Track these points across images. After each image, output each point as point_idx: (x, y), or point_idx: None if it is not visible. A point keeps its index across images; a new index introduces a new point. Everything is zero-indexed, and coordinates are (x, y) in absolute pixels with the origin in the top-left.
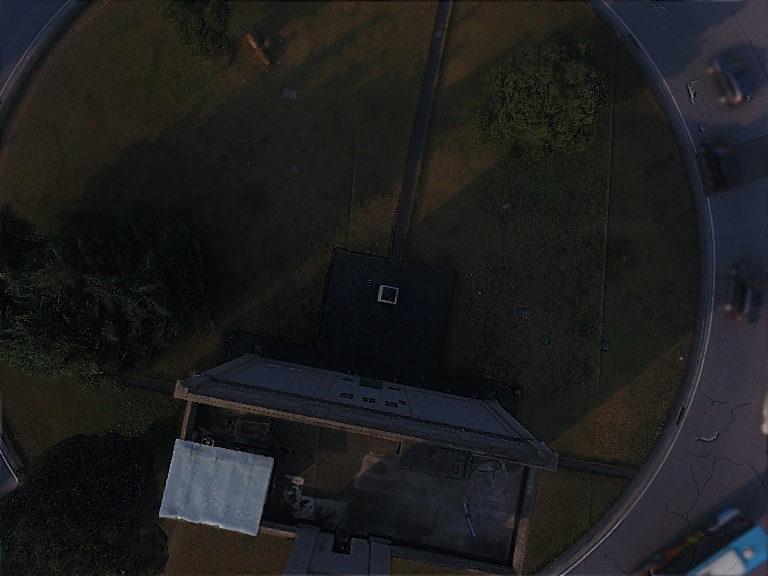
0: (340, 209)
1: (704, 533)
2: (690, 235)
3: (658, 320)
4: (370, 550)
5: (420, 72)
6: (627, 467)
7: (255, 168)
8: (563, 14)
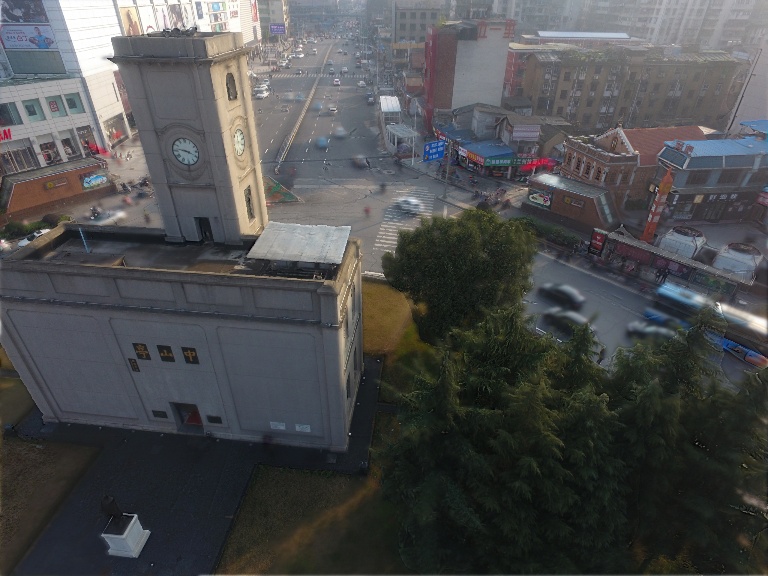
0: None
1: None
2: None
3: None
4: (179, 225)
5: None
6: None
7: None
8: None
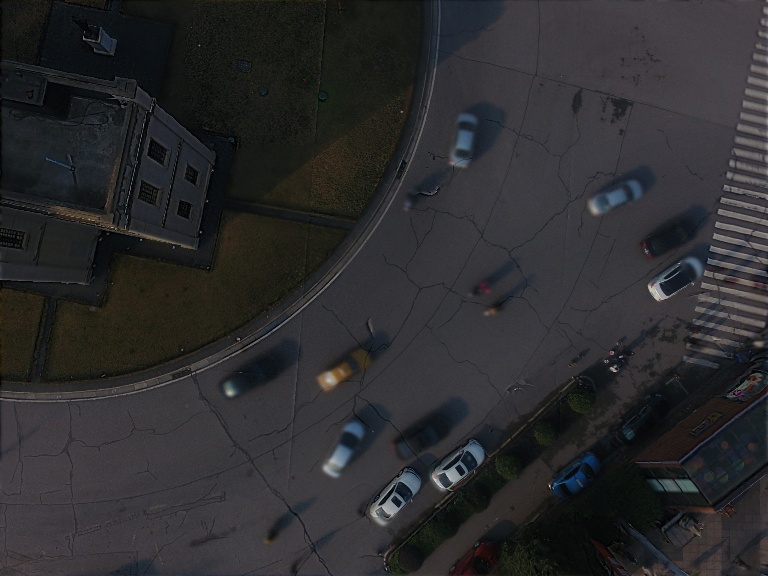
0: None
1: (423, 285)
2: None
3: (378, 73)
4: None
5: None
6: (344, 218)
7: None
8: None
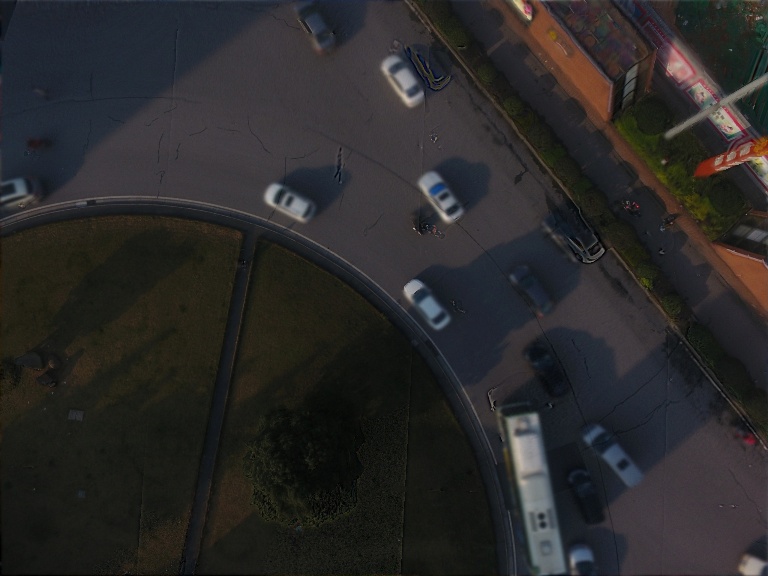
0: (129, 535)
1: None
2: (489, 553)
3: None
4: None
5: (210, 388)
6: None
7: (41, 494)
8: (357, 323)
